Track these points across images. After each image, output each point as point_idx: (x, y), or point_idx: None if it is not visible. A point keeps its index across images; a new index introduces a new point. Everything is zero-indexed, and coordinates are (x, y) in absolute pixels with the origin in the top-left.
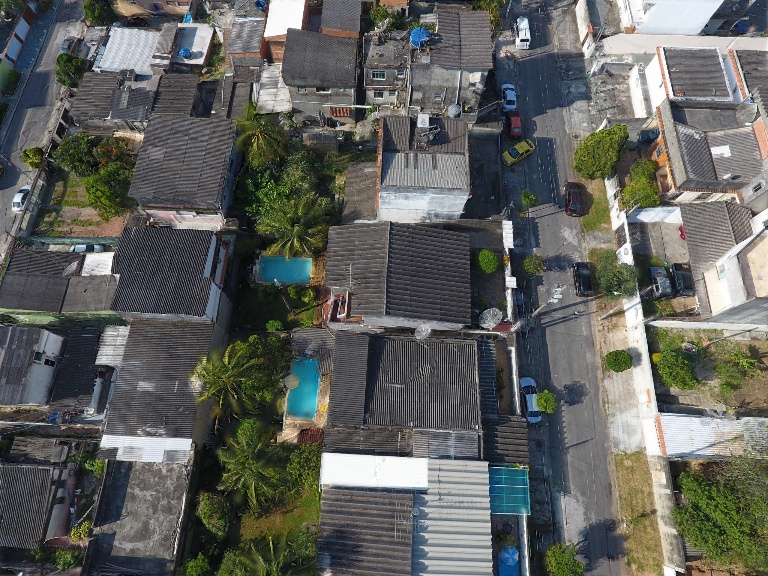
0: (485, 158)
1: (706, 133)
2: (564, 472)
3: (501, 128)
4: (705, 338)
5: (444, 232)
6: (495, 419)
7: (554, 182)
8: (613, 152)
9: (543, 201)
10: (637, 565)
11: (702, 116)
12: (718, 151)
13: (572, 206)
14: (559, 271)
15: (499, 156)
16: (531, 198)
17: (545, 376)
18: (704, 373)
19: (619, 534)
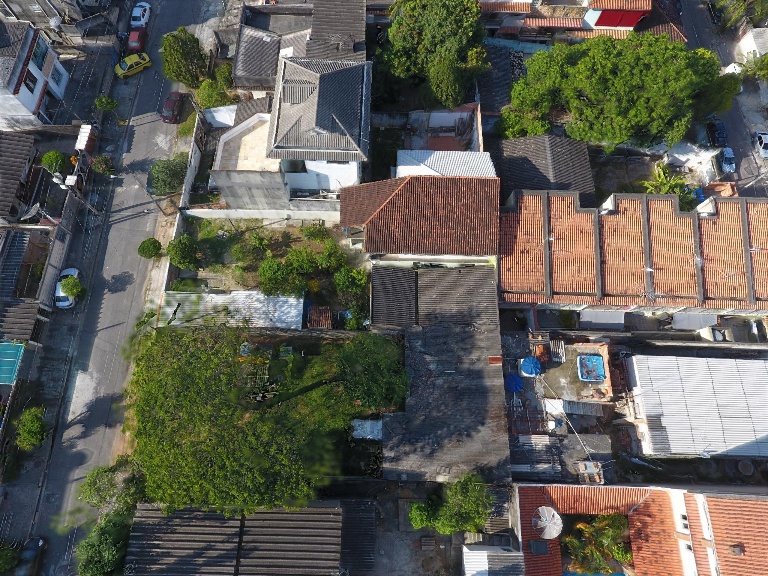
0: (102, 72)
1: (281, 37)
2: (87, 353)
3: (111, 41)
4: (243, 227)
5: (6, 133)
6: (8, 301)
7: (164, 93)
8: (177, 54)
9: (147, 110)
10: (130, 432)
11: (285, 22)
12: (284, 52)
13: (164, 112)
14: (141, 173)
15: (109, 68)
16: (103, 101)
17: (97, 268)
18: (231, 257)
19: (123, 405)
